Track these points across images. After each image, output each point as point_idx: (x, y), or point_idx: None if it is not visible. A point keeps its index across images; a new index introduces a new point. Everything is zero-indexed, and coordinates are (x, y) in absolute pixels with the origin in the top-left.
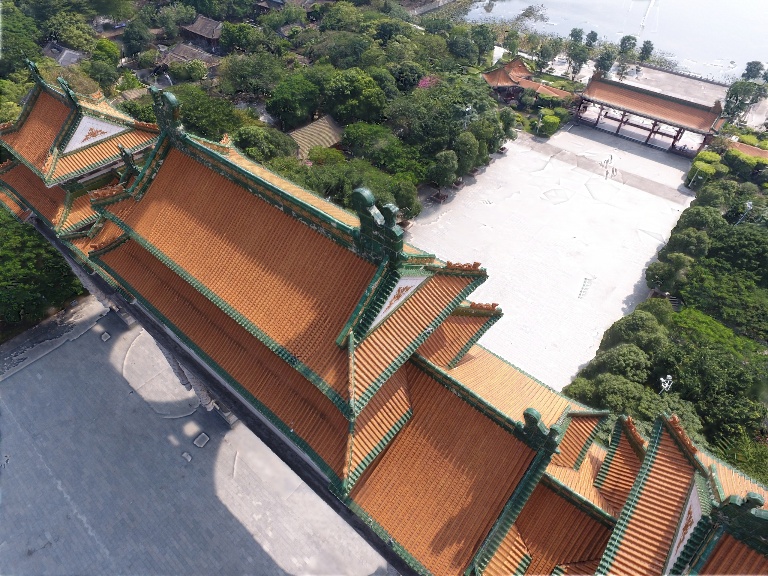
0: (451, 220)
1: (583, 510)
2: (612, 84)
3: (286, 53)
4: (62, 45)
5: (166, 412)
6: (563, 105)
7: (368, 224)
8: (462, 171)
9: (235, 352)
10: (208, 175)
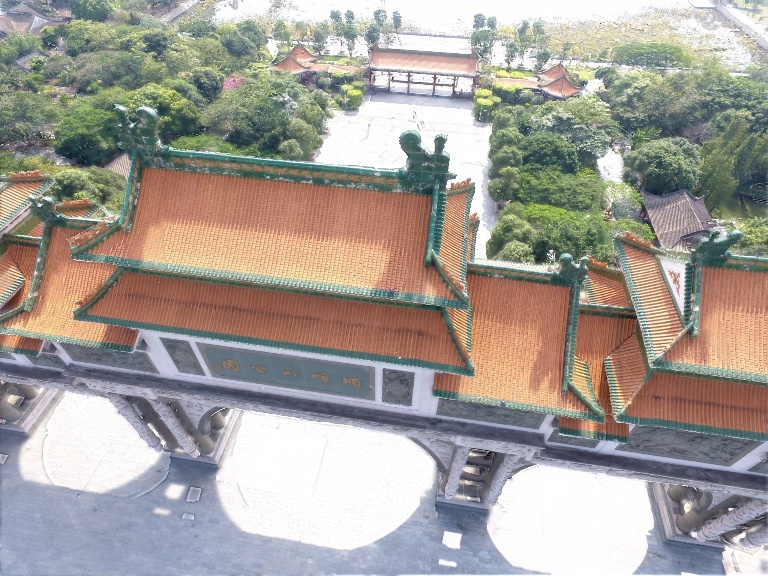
0: None
1: (605, 315)
2: (390, 52)
3: (42, 87)
4: None
5: (135, 491)
6: (356, 79)
7: (418, 159)
8: (305, 157)
9: (309, 326)
10: (207, 180)
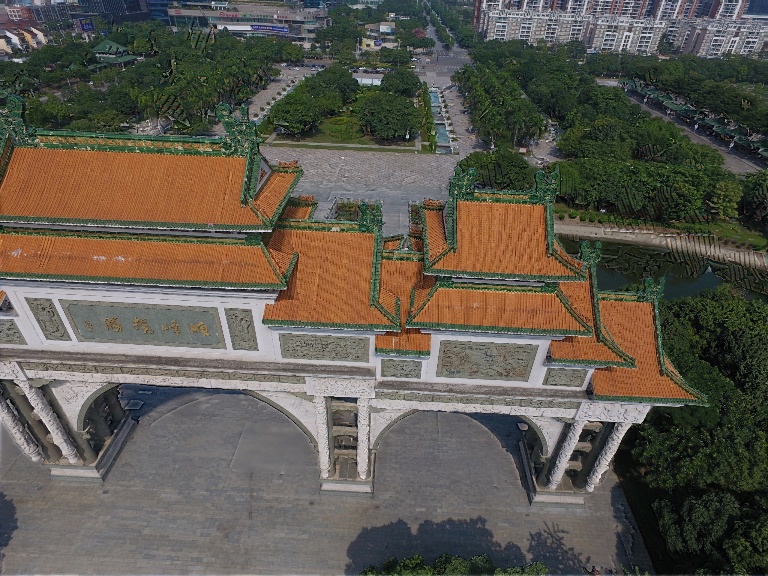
0: None
1: None
2: None
3: None
4: None
5: None
6: None
7: None
8: None
9: None
10: None
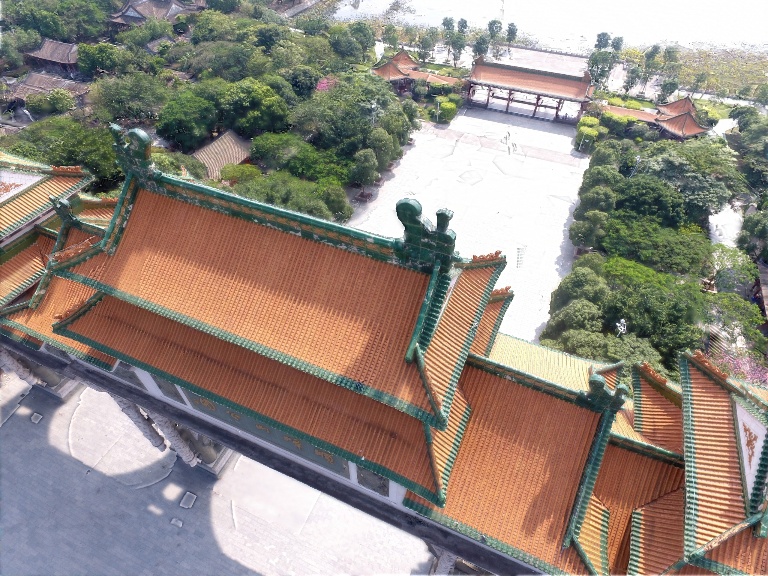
0: (382, 217)
1: (645, 454)
2: (494, 66)
3: (162, 71)
4: None
5: (137, 482)
6: (454, 91)
7: (416, 233)
8: (381, 167)
9: (273, 394)
10: (196, 213)
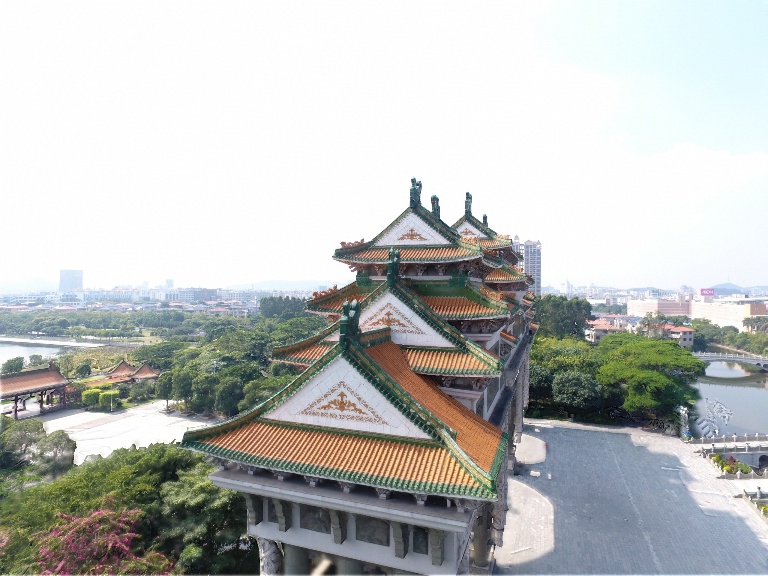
0: None
1: None
2: None
3: None
4: None
5: None
6: None
7: None
8: None
9: None
10: None
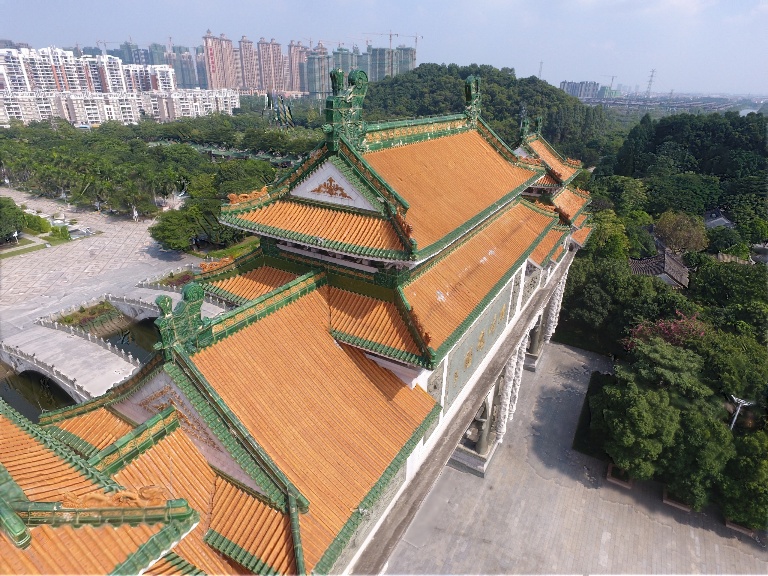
0: None
1: None
2: None
3: None
4: (724, 214)
5: None
6: None
7: None
8: None
9: None
10: None
